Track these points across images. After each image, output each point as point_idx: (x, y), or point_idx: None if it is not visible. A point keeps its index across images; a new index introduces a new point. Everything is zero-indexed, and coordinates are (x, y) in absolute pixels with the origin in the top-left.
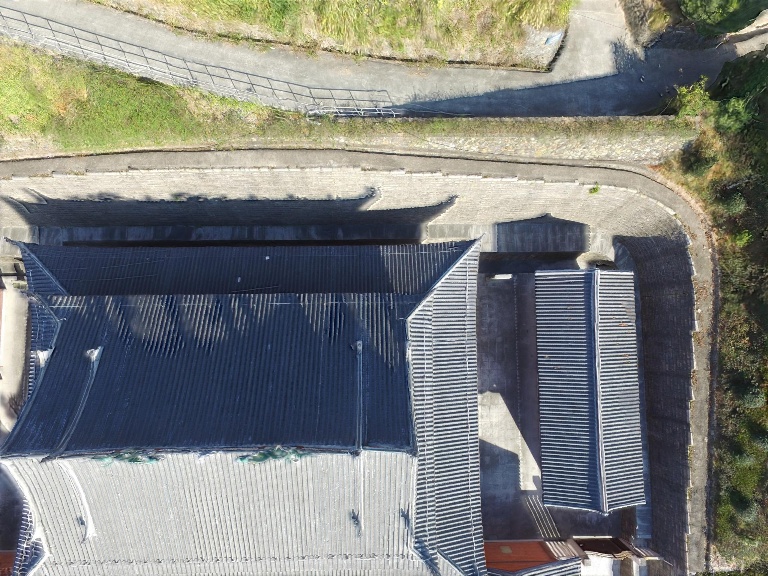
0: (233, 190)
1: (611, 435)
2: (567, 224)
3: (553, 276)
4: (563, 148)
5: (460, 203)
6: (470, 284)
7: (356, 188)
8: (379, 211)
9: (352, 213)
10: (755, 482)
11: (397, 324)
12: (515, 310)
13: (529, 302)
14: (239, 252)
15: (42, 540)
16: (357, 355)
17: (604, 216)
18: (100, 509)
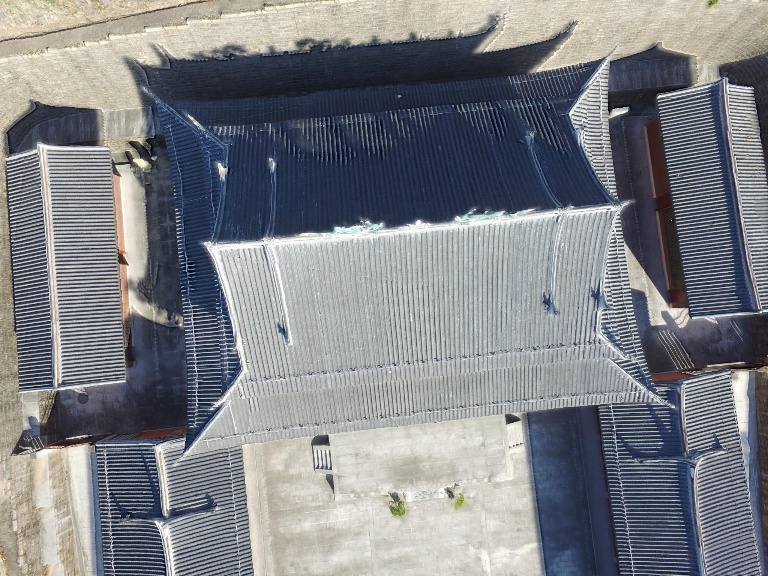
0: (360, 31)
1: (752, 241)
2: (673, 58)
3: (677, 96)
4: None
5: (577, 33)
6: (602, 103)
7: (482, 17)
8: (494, 53)
9: (467, 58)
10: None
11: (559, 119)
12: (626, 153)
13: (639, 144)
14: (370, 94)
15: (240, 353)
16: (529, 146)
17: (714, 40)
18: (298, 313)
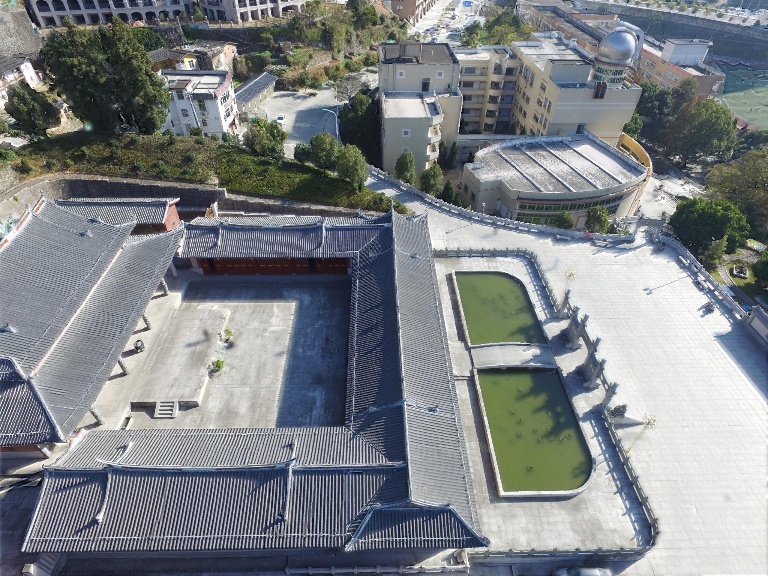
0: None
1: None
2: None
3: None
4: None
5: None
6: None
7: None
8: None
9: None
10: (177, 168)
11: None
12: None
13: None
14: None
15: None
16: None
17: None
18: None
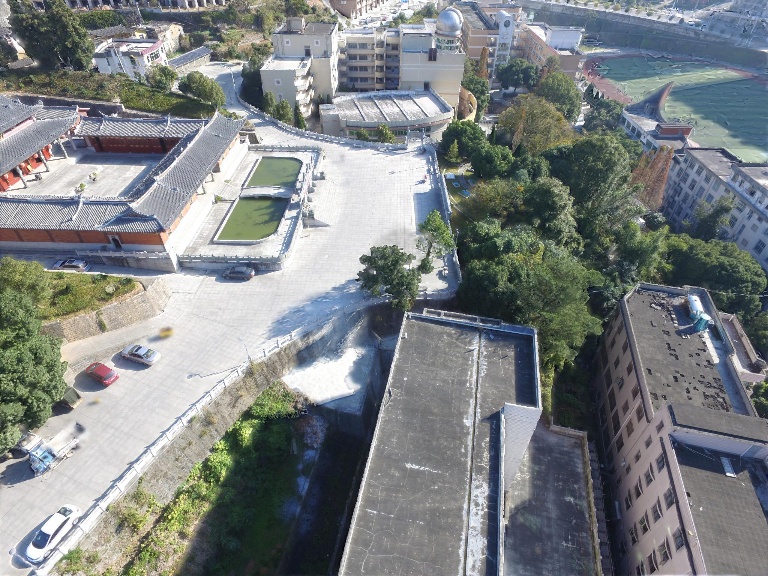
0: None
1: None
2: None
3: None
4: None
5: None
6: None
7: None
8: None
9: None
10: None
11: None
12: None
13: None
14: None
15: None
16: None
17: None
18: None
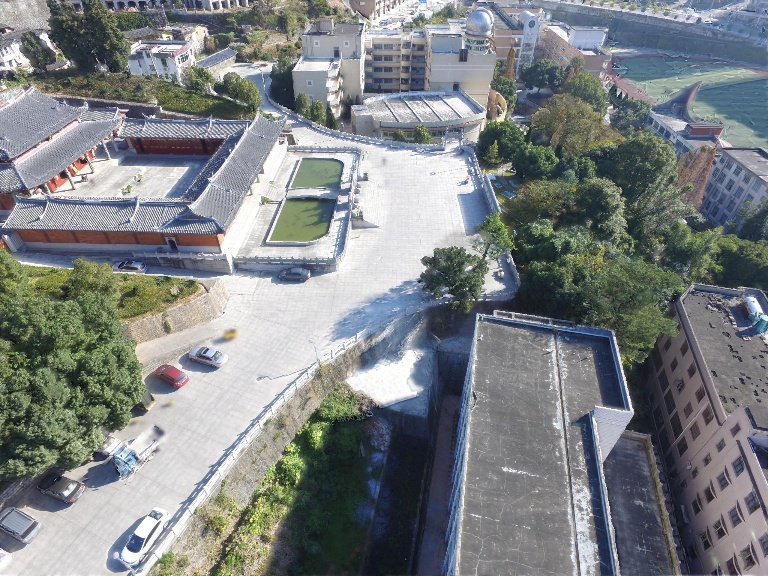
0: None
1: None
2: None
3: None
4: (0, 101)
5: None
6: None
7: None
8: None
9: None
10: (130, 93)
11: None
12: None
13: None
14: None
15: None
16: None
17: None
18: None
